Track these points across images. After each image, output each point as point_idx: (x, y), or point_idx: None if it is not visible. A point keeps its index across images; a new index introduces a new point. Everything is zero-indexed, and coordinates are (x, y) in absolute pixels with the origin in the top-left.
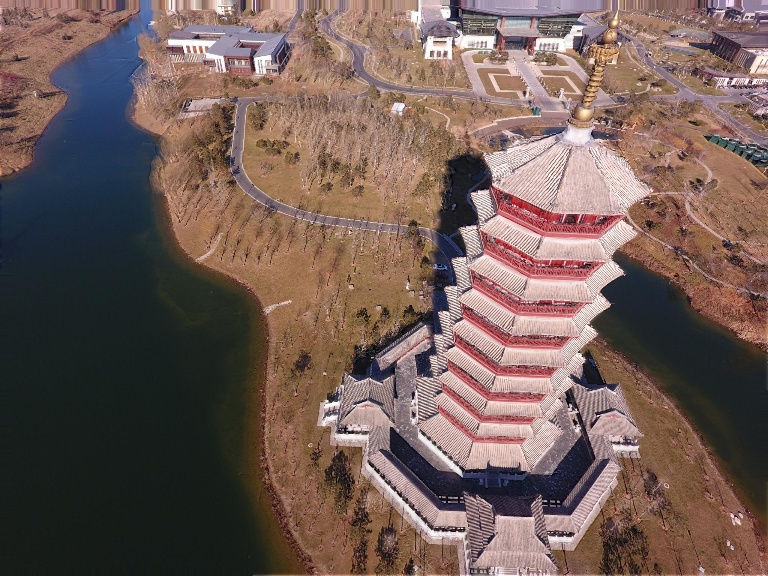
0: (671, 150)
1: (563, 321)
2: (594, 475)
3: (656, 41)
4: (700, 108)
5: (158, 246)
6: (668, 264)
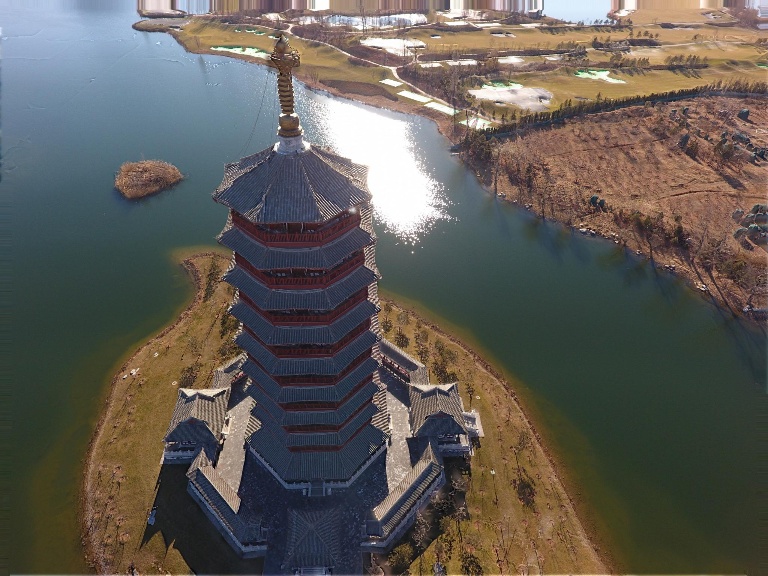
0: None
1: None
2: None
3: None
4: None
5: None
6: None
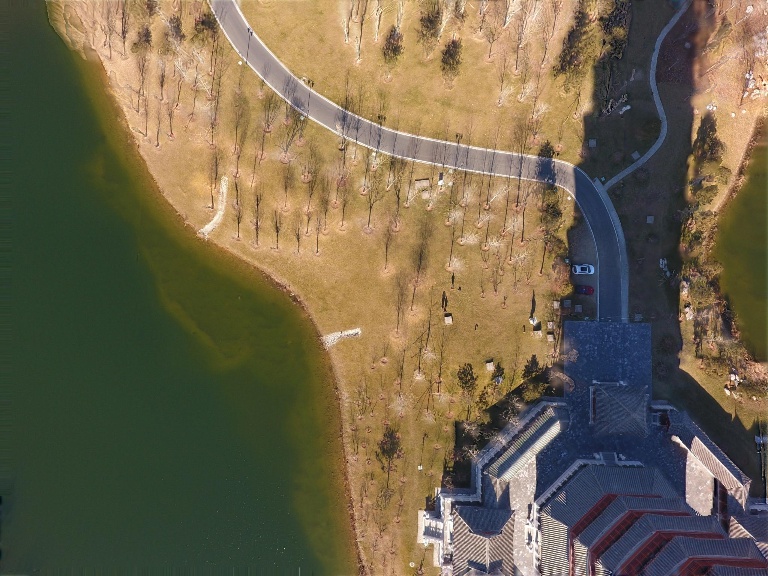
0: None
1: None
2: None
3: None
4: None
5: (128, 193)
6: None
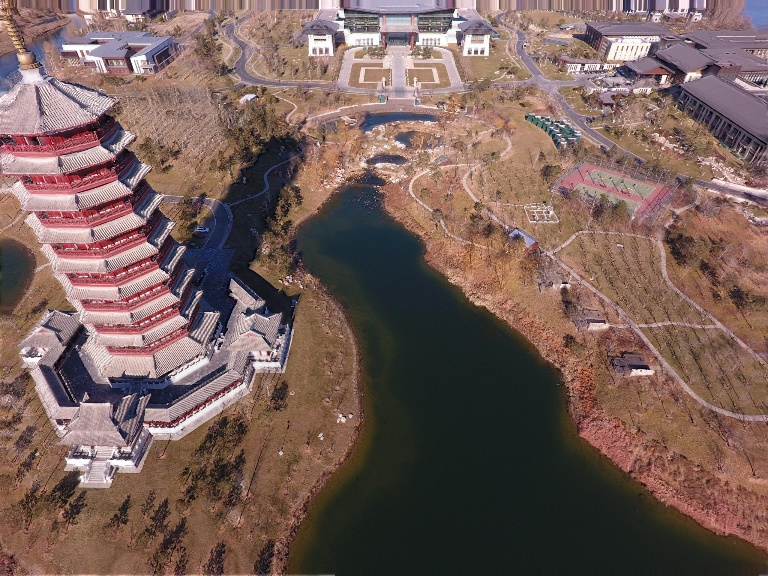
0: (489, 129)
1: (86, 232)
2: (211, 380)
3: (540, 34)
4: (537, 91)
5: None
6: (423, 224)
